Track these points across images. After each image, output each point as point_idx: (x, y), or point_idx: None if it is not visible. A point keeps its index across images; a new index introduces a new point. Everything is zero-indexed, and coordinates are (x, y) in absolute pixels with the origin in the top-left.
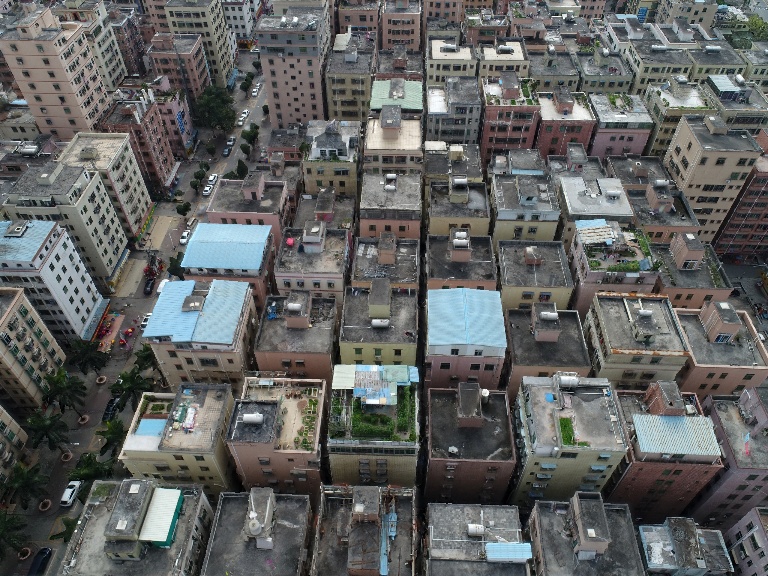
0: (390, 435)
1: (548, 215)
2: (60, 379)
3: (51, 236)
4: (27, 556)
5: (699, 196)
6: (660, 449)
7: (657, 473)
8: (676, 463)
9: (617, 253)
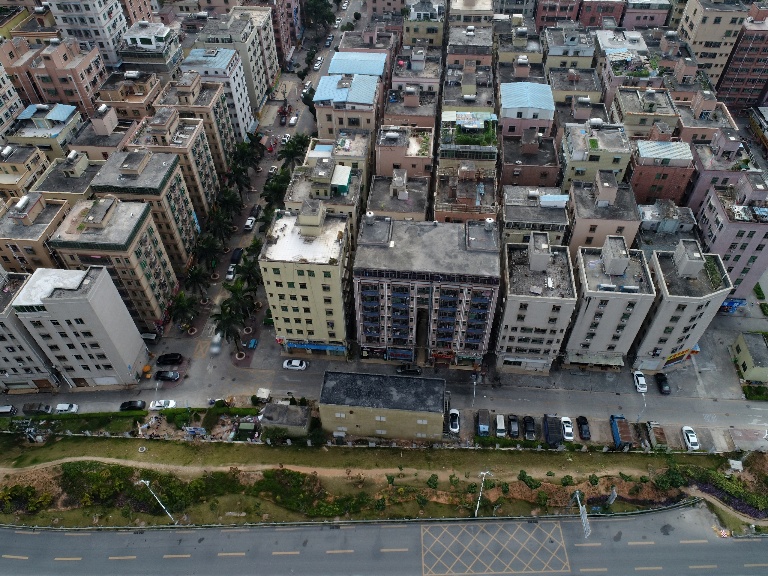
0: (480, 142)
1: (586, 51)
2: (245, 147)
3: (234, 58)
4: (228, 251)
5: (701, 52)
6: (654, 156)
7: (652, 178)
8: (664, 166)
9: (634, 67)
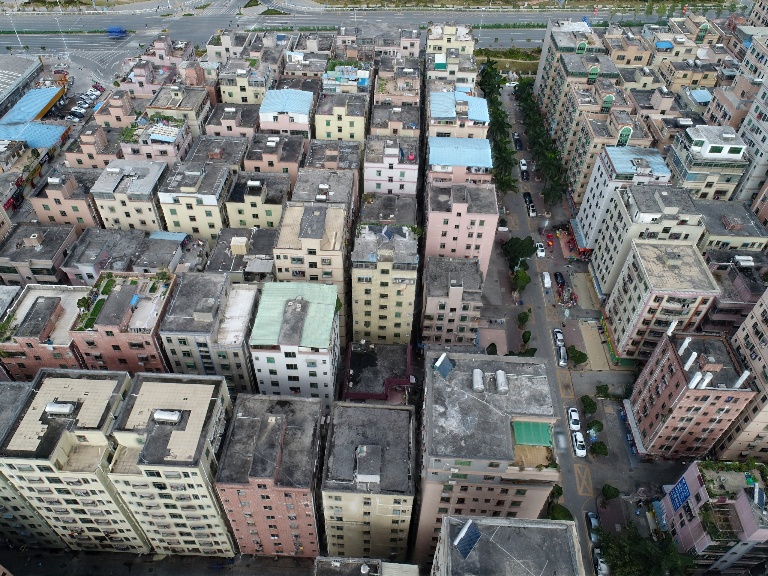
0: None
1: None
2: None
3: None
4: None
5: None
6: None
7: None
8: None
9: None
